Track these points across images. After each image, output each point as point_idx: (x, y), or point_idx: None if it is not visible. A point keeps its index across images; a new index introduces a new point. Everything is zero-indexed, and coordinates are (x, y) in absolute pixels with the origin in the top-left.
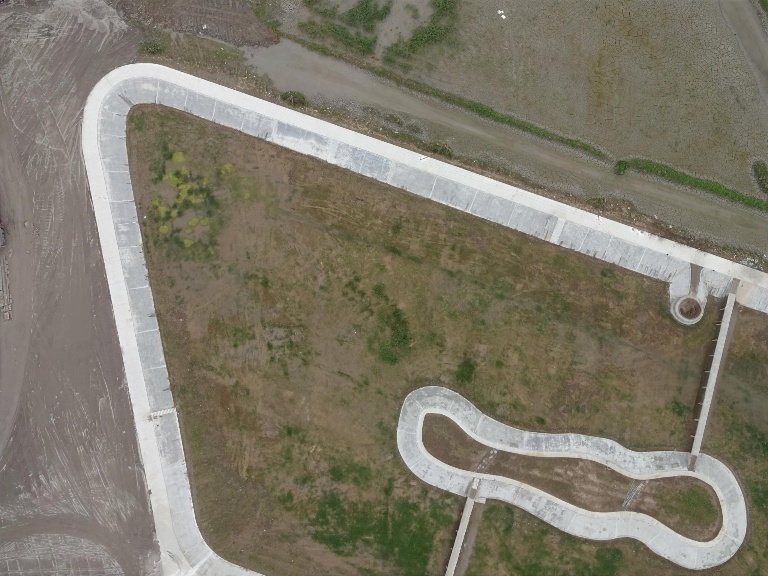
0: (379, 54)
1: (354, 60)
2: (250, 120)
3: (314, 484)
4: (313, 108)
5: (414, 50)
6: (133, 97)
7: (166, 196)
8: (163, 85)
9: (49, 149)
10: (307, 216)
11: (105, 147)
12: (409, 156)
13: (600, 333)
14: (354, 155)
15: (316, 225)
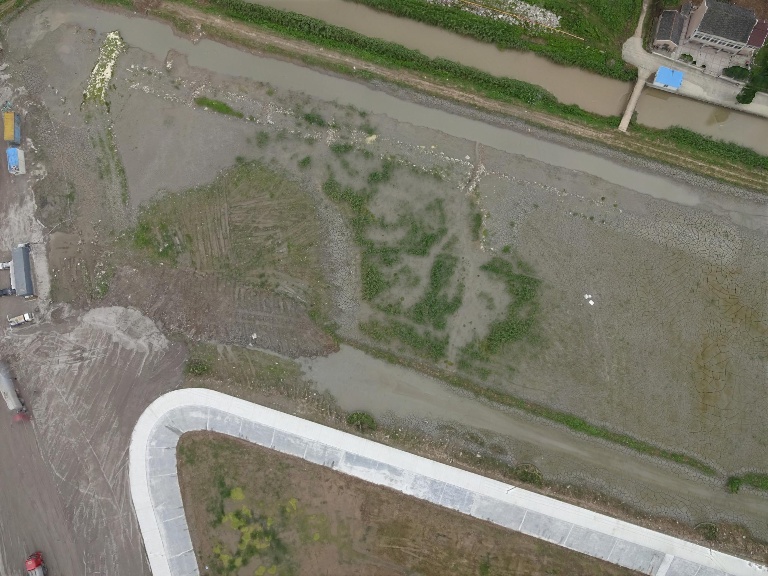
0: (452, 357)
1: (425, 369)
2: (314, 449)
3: None
4: (383, 432)
5: (492, 352)
6: (181, 425)
7: (227, 541)
8: (214, 412)
9: (95, 499)
10: (384, 558)
11: (156, 492)
12: (495, 487)
13: None
14: (433, 487)
15: (395, 568)
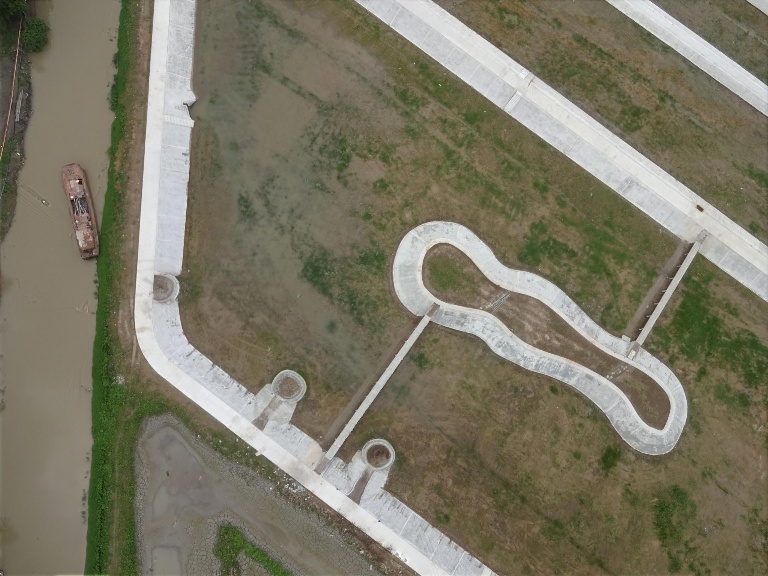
0: None
1: None
2: None
3: (764, 397)
4: None
5: None
6: None
7: None
8: None
9: None
10: None
11: None
12: None
13: (471, 457)
14: None
15: None
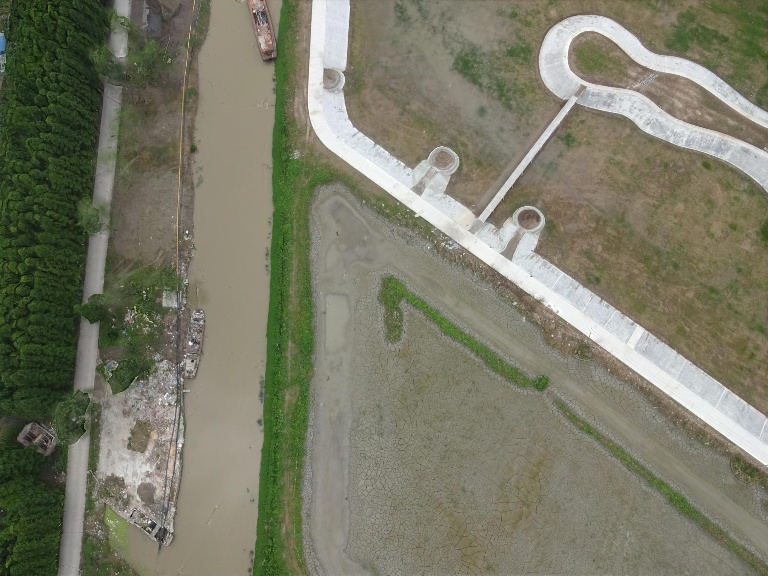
0: None
1: None
2: None
3: None
4: None
5: None
6: None
7: None
8: None
9: None
10: None
11: None
12: None
13: (620, 226)
14: None
15: None
